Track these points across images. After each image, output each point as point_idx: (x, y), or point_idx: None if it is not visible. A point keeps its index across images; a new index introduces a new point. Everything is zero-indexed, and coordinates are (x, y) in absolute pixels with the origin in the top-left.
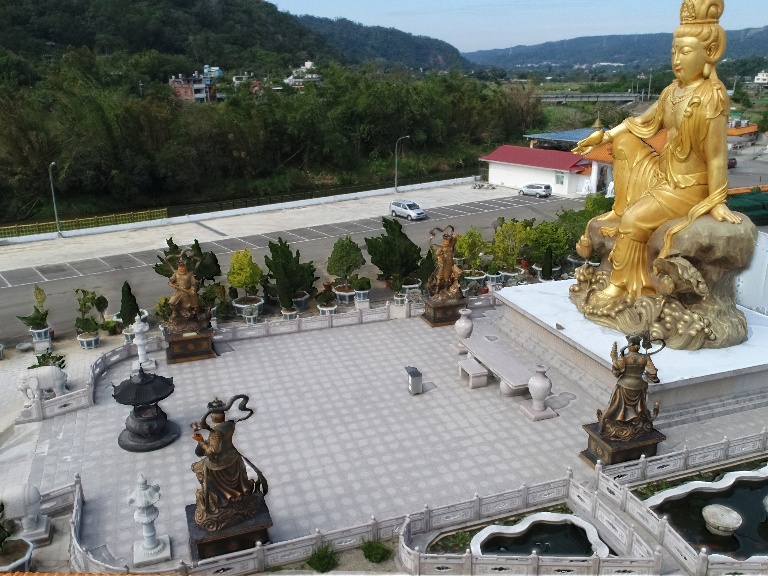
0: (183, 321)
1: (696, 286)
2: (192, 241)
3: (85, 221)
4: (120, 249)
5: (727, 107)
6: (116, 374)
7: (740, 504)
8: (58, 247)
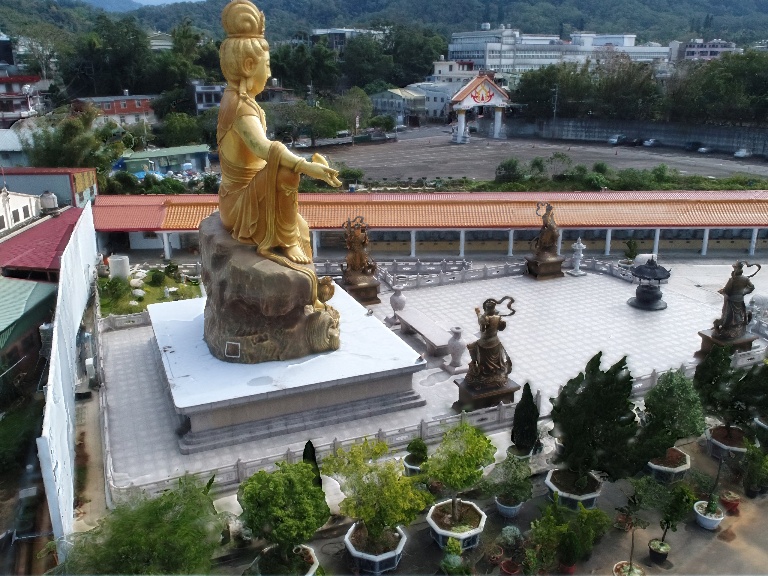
0: None
1: None
2: None
3: None
4: None
5: None
6: None
7: None
8: None
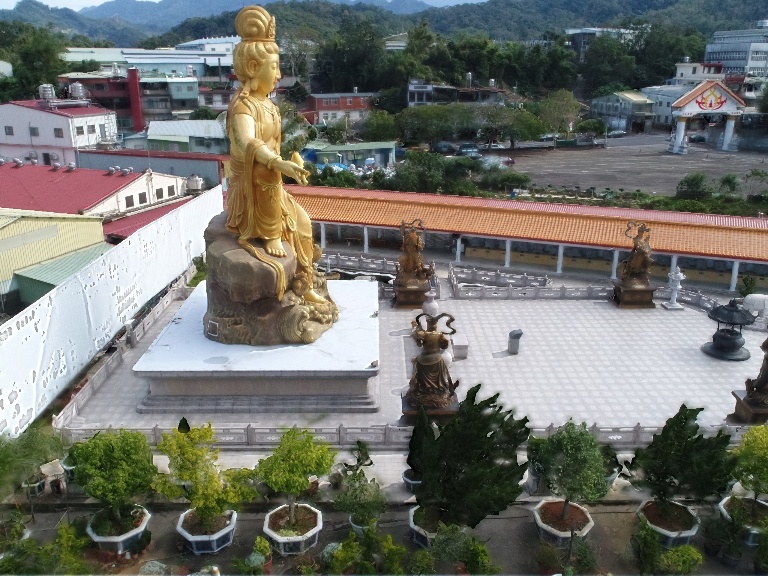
0: None
1: None
2: None
3: None
4: None
5: None
6: None
7: None
8: None
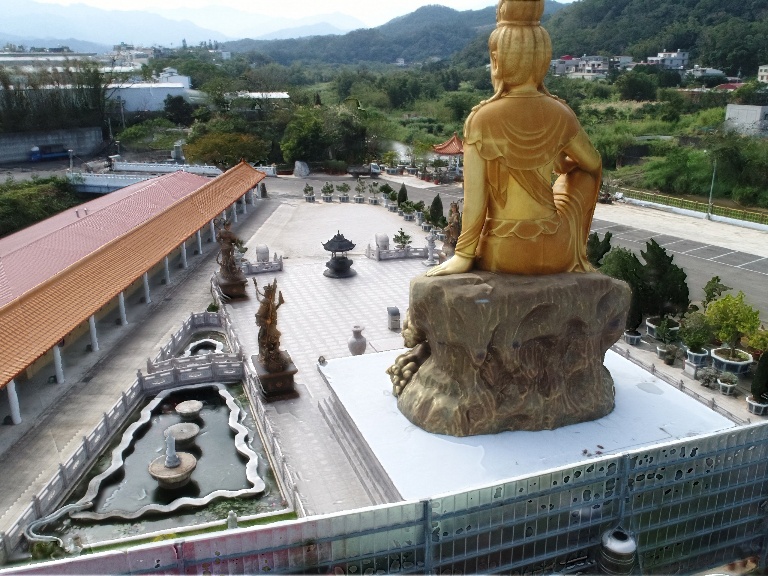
0: (449, 245)
1: (405, 326)
2: (758, 252)
3: (735, 211)
4: (697, 236)
5: (472, 134)
6: (419, 260)
7: (223, 441)
8: (679, 222)
